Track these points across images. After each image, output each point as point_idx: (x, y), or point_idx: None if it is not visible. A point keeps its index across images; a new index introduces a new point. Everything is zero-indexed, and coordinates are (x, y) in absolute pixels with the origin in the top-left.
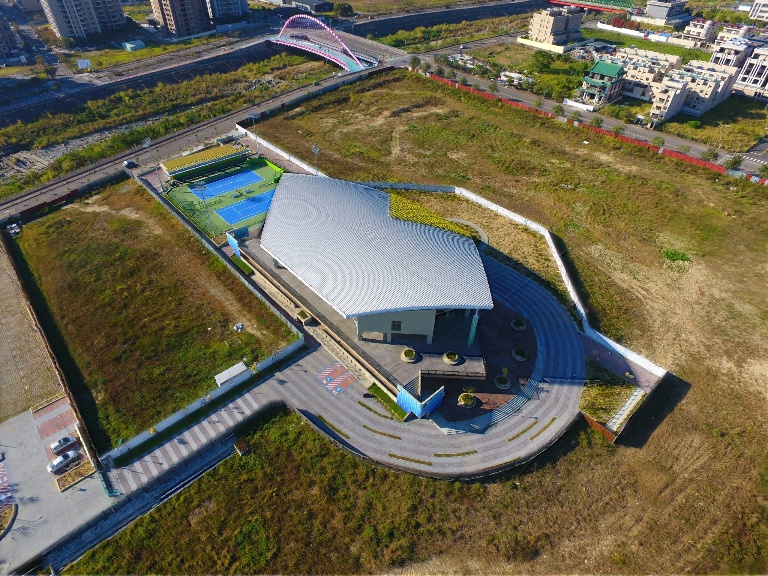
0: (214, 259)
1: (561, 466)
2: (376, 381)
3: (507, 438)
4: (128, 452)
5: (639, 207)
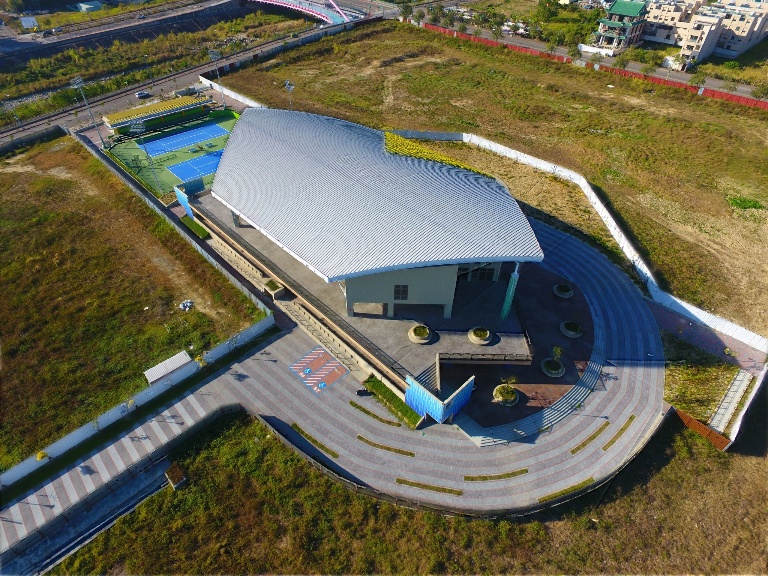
0: (159, 221)
1: (655, 489)
2: (374, 372)
3: (569, 448)
4: (3, 490)
5: (688, 151)
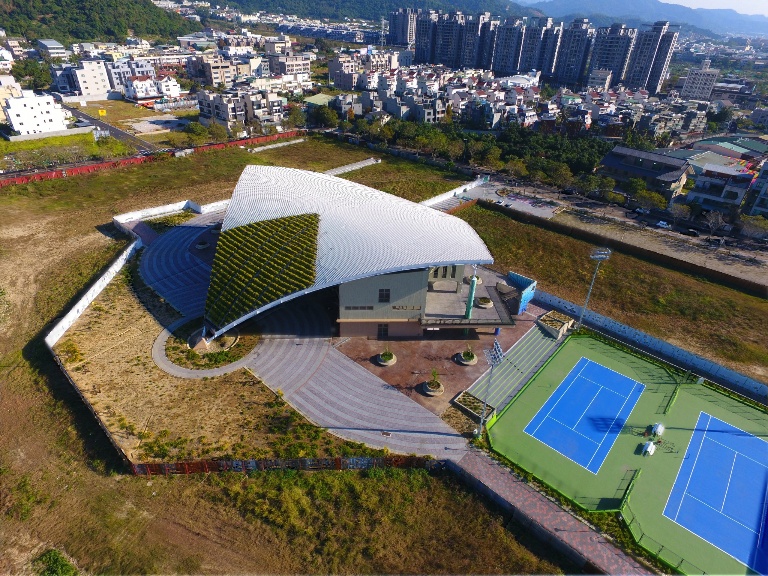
0: None
1: None
2: None
3: None
4: None
5: None
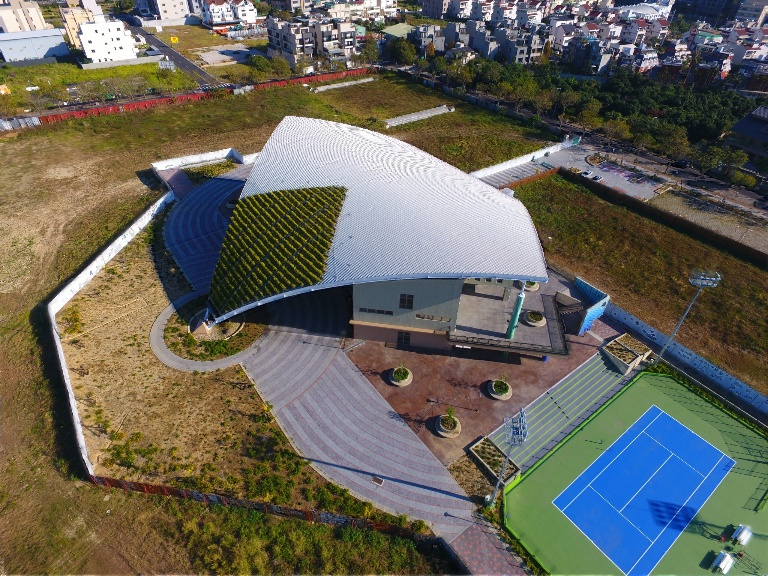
0: None
1: None
2: None
3: None
4: None
5: None
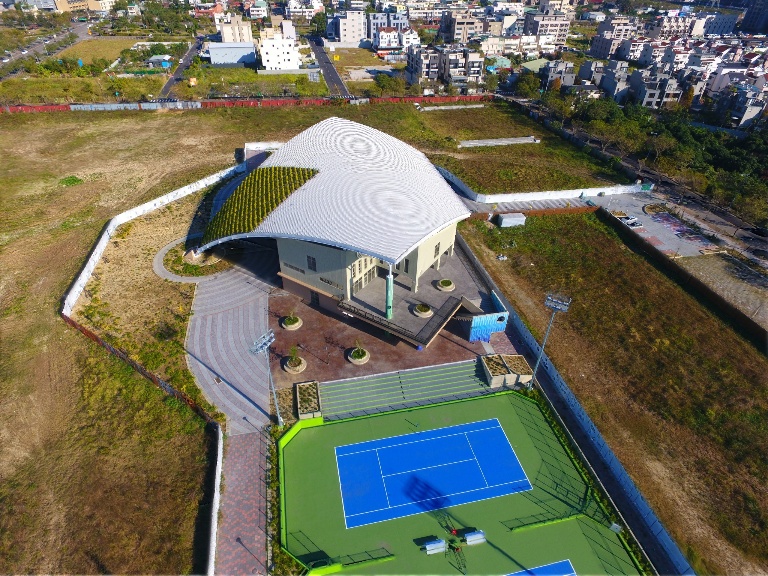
0: None
1: None
2: None
3: None
4: None
5: None
